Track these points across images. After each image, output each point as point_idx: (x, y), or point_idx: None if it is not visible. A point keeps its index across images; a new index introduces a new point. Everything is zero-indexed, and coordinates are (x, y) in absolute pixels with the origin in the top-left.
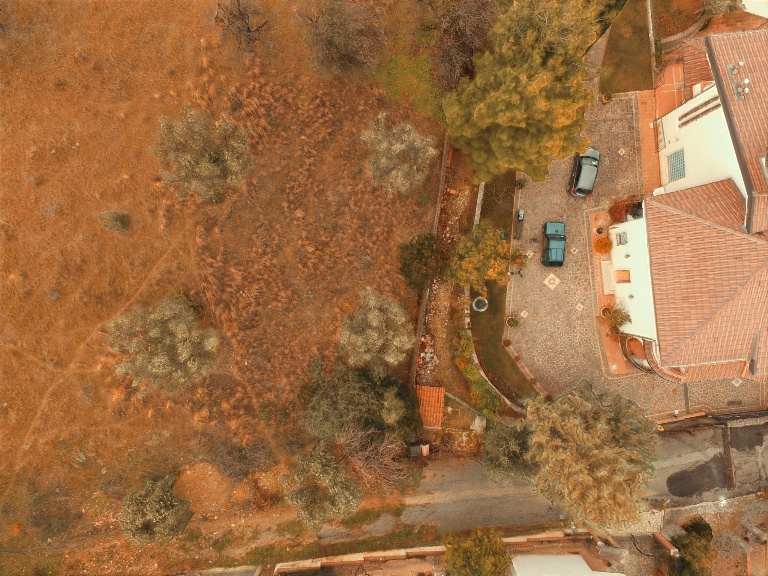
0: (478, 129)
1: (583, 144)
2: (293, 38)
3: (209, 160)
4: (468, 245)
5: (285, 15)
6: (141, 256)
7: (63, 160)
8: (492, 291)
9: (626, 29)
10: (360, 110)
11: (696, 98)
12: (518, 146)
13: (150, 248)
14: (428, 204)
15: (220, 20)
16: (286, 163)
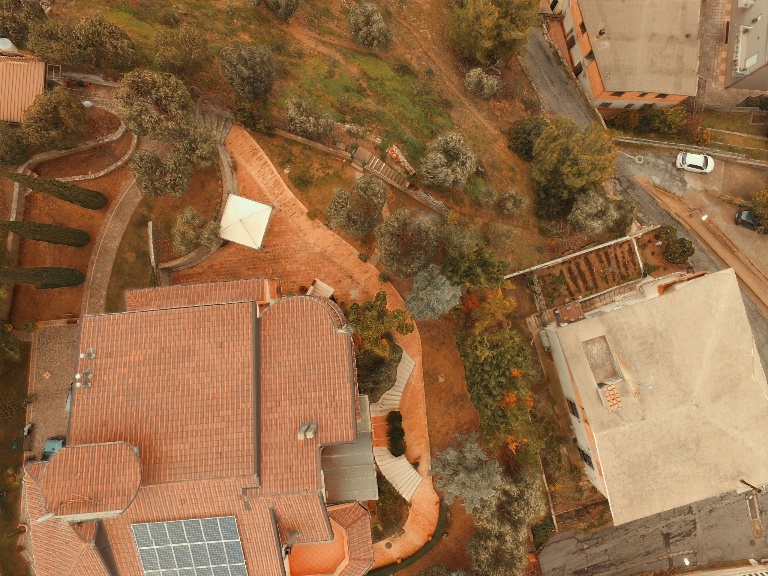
0: None
1: None
2: None
3: None
4: None
5: None
6: None
7: None
8: (7, 498)
9: (130, 253)
10: None
11: None
12: None
13: None
14: None
15: None
16: None
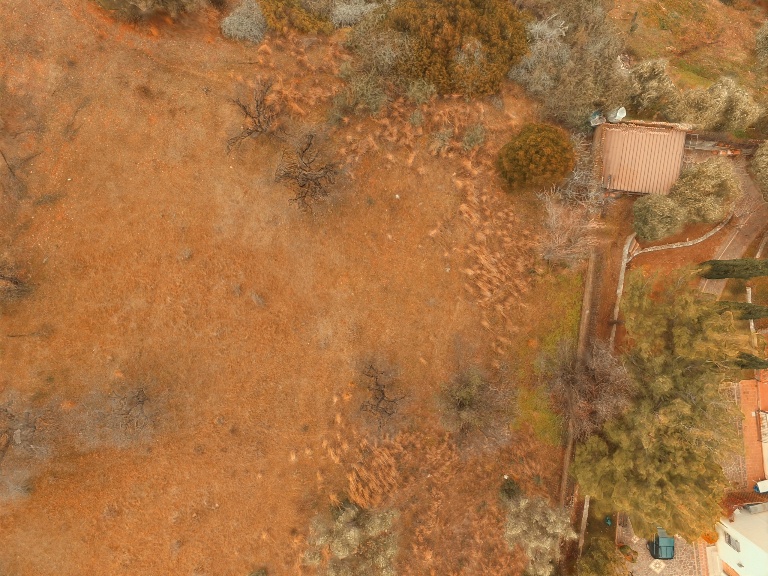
0: None
1: (717, 516)
2: (419, 382)
3: (365, 568)
4: None
5: (411, 360)
6: None
7: (203, 521)
8: None
9: None
10: (484, 447)
11: None
12: None
13: None
14: None
15: None
16: (415, 505)
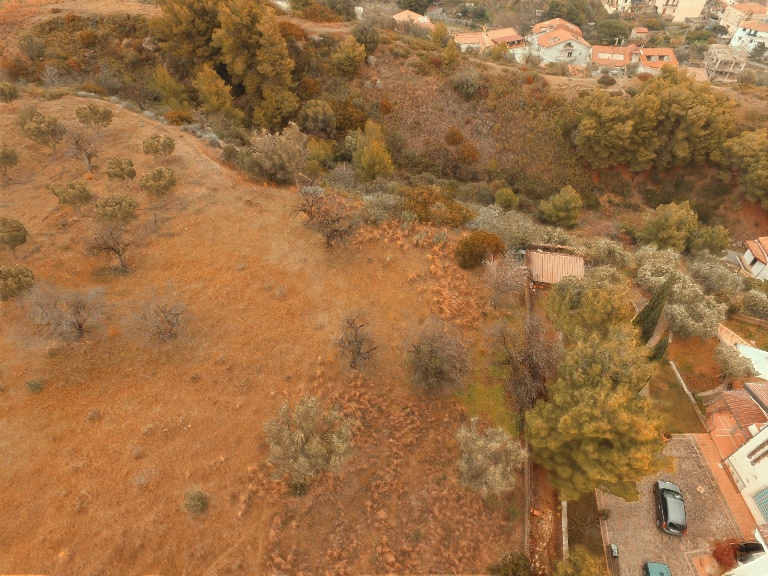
0: (561, 442)
1: (669, 462)
2: (390, 363)
3: (317, 441)
4: (569, 572)
5: (386, 348)
6: (205, 547)
7: (170, 438)
8: None
9: (662, 384)
10: (445, 421)
11: (757, 436)
12: (605, 459)
13: (218, 538)
14: (515, 520)
15: (342, 342)
16: (374, 462)
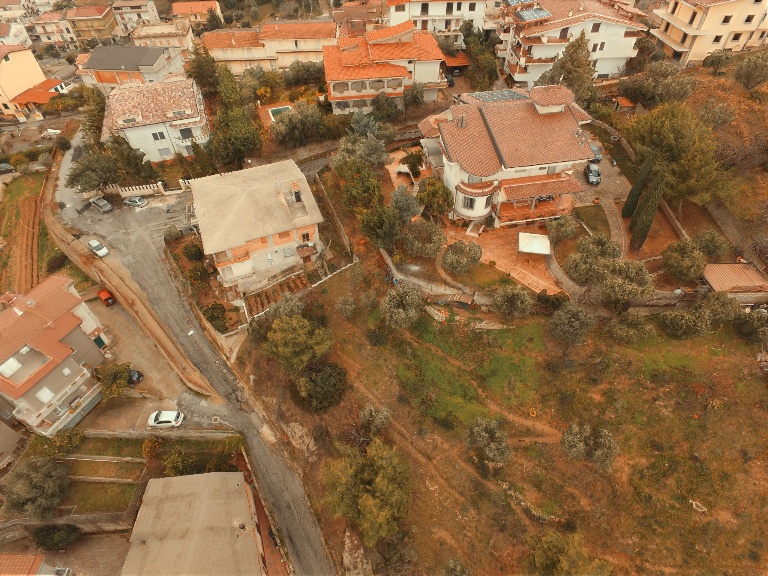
0: None
1: None
2: None
3: None
4: None
5: None
6: None
7: None
8: None
9: None
10: None
11: None
12: None
13: None
14: None
15: None
16: None
